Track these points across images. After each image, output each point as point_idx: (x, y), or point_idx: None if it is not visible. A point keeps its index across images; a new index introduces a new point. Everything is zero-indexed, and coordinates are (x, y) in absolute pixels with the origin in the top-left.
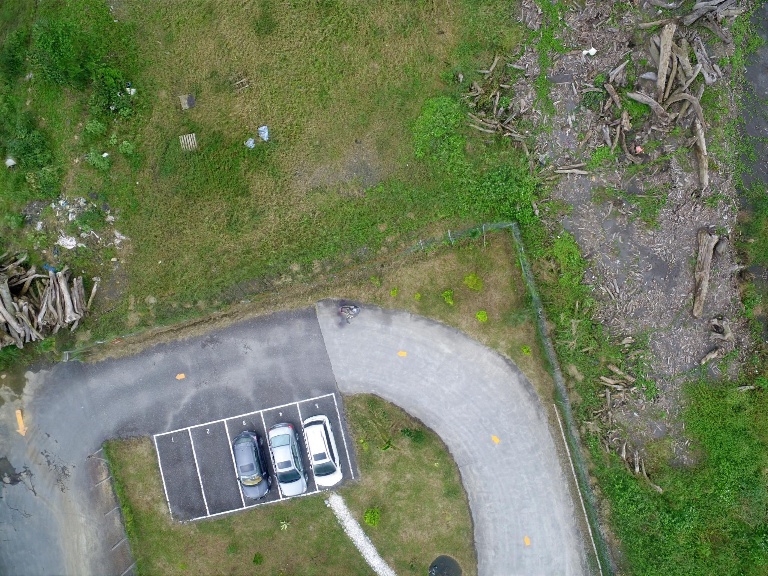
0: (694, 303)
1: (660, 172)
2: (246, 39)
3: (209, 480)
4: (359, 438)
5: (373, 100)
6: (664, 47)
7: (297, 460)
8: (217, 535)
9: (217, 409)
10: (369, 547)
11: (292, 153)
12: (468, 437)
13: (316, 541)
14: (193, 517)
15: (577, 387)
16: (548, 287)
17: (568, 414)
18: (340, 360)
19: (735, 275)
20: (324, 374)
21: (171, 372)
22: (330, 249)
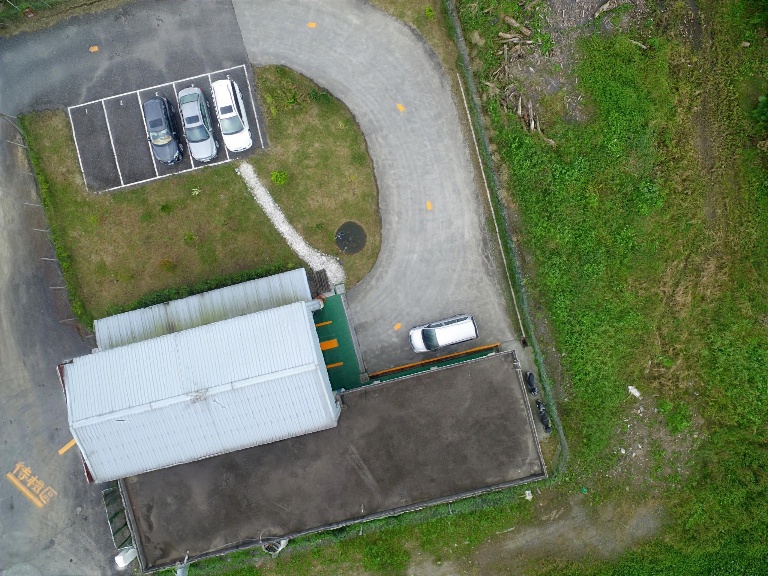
0: None
1: None
2: None
3: (123, 150)
4: (269, 108)
5: None
6: None
7: (206, 120)
8: (131, 205)
9: (130, 81)
10: (278, 214)
11: None
12: (374, 106)
13: (227, 209)
14: (107, 187)
15: (479, 53)
16: None
17: (470, 80)
18: (251, 31)
19: None
20: (235, 46)
21: (84, 45)
22: None
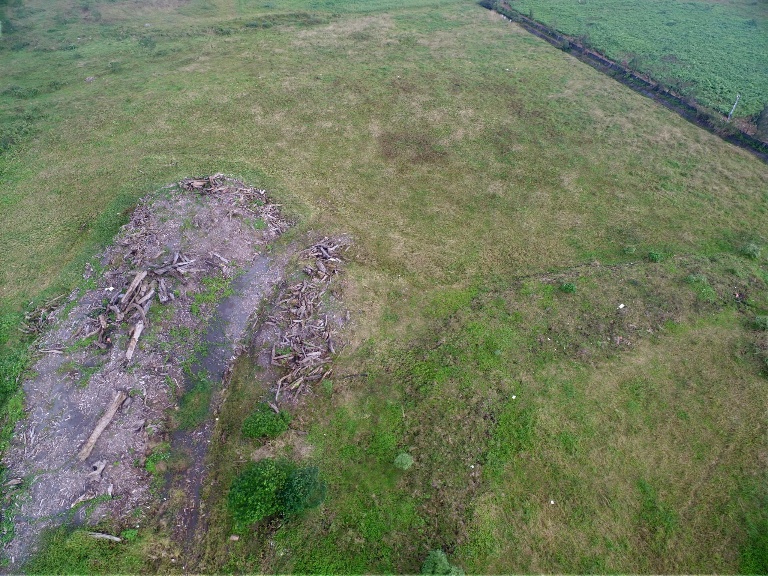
0: None
1: None
2: None
3: None
4: None
5: None
6: None
7: None
8: None
9: None
10: None
11: None
12: None
13: None
14: None
15: None
16: None
17: None
18: None
19: (151, 433)
20: None
21: None
22: None
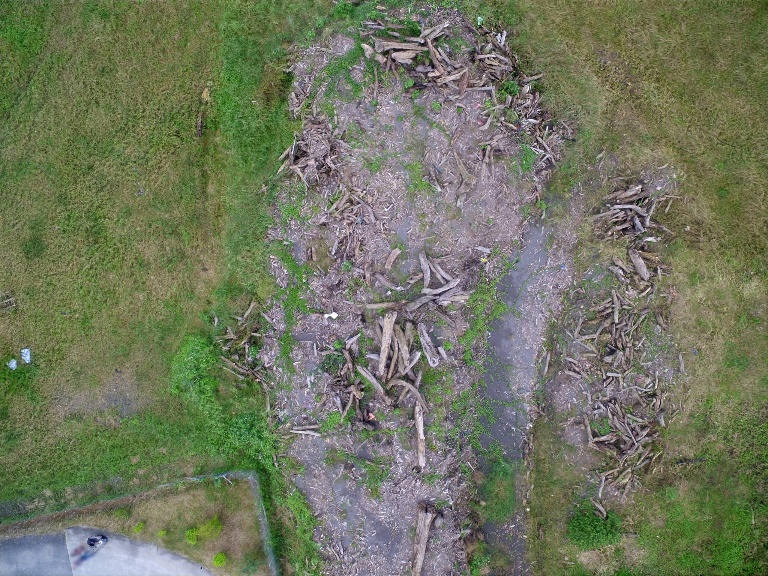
0: (412, 572)
1: (386, 443)
2: (15, 259)
3: None
4: None
5: (134, 332)
6: (384, 335)
7: None
8: None
9: None
10: None
11: (53, 377)
12: None
13: None
14: None
15: None
16: (289, 532)
17: None
18: None
19: (464, 536)
20: None
21: None
22: (81, 479)
